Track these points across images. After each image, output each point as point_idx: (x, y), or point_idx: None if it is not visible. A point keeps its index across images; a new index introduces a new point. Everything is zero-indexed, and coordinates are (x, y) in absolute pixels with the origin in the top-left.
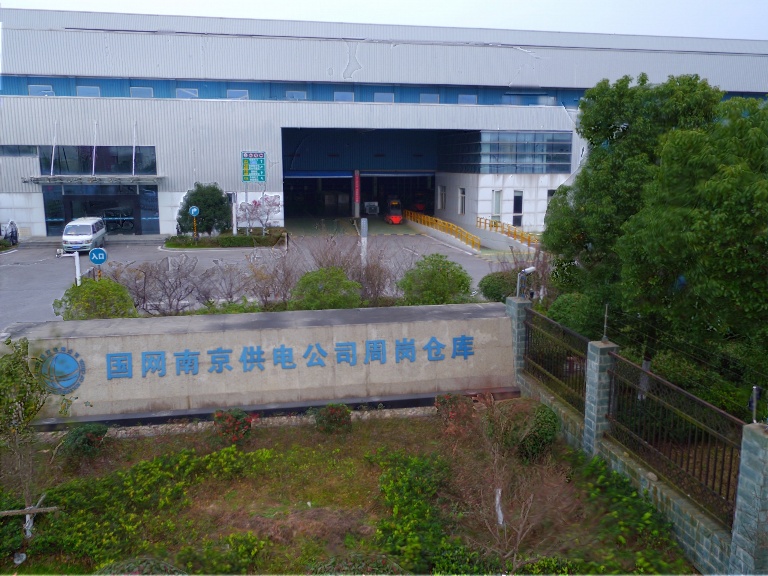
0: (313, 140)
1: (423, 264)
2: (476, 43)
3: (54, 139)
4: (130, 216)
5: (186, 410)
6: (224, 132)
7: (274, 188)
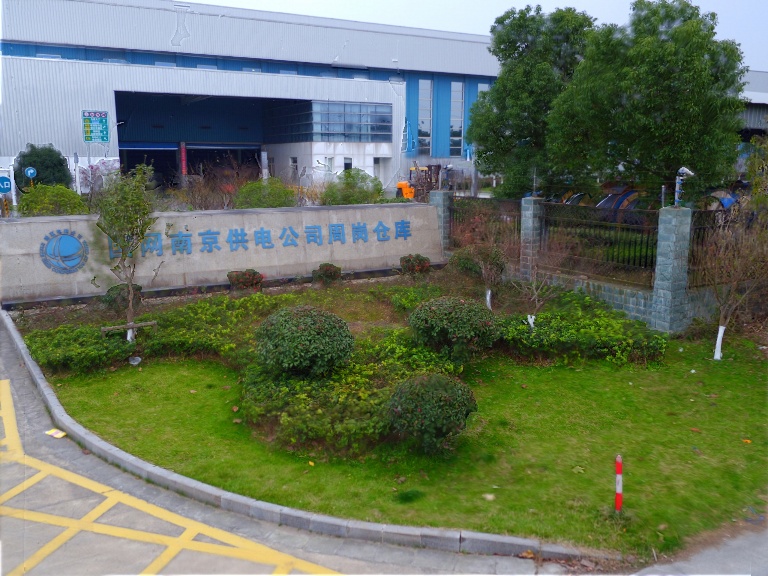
0: (135, 110)
1: (343, 177)
2: (294, 21)
3: None
4: None
5: (183, 285)
6: (51, 93)
7: (109, 153)
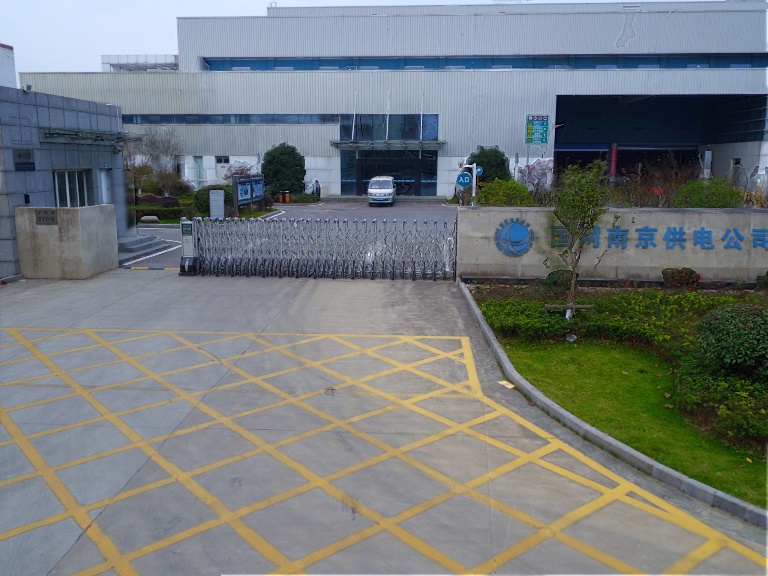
0: (572, 113)
1: None
2: (756, 8)
3: (354, 108)
4: (411, 179)
5: (615, 278)
6: (502, 100)
7: (545, 154)
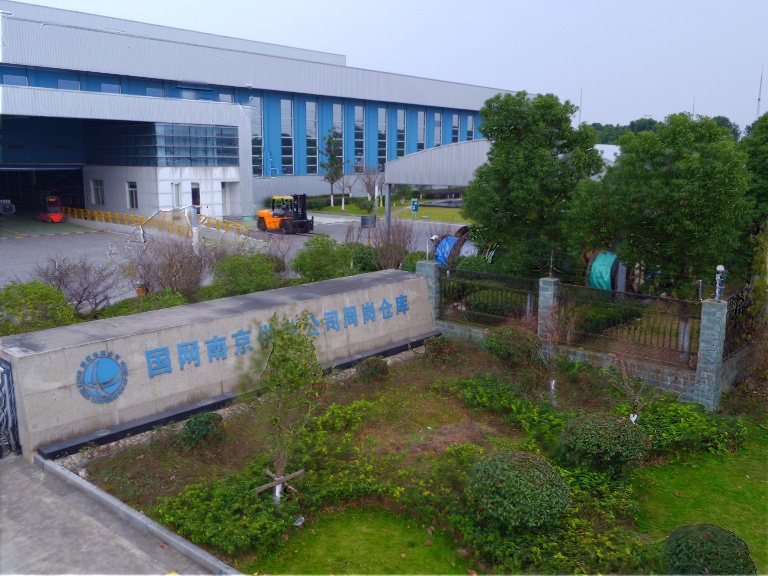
0: None
1: (311, 244)
2: (117, 31)
3: None
4: None
5: (222, 395)
6: None
7: None
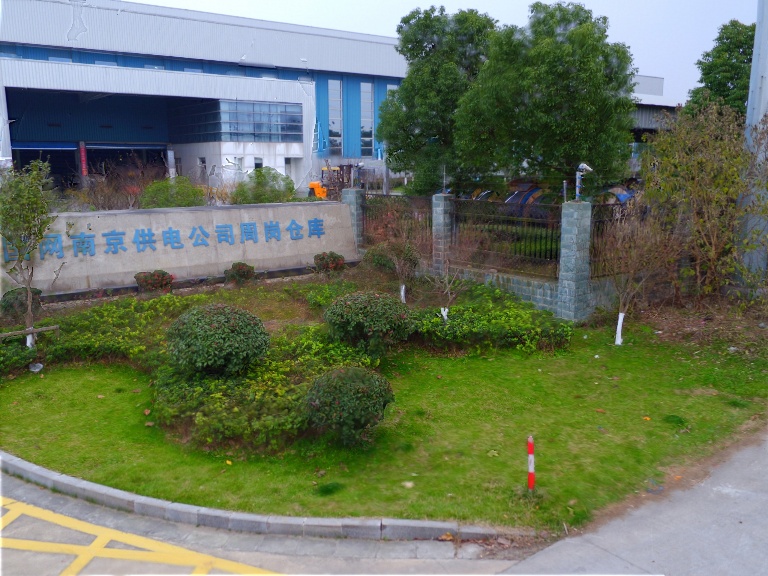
0: (29, 108)
1: (254, 176)
2: (199, 18)
3: None
4: None
5: (87, 289)
6: None
7: (1, 153)
